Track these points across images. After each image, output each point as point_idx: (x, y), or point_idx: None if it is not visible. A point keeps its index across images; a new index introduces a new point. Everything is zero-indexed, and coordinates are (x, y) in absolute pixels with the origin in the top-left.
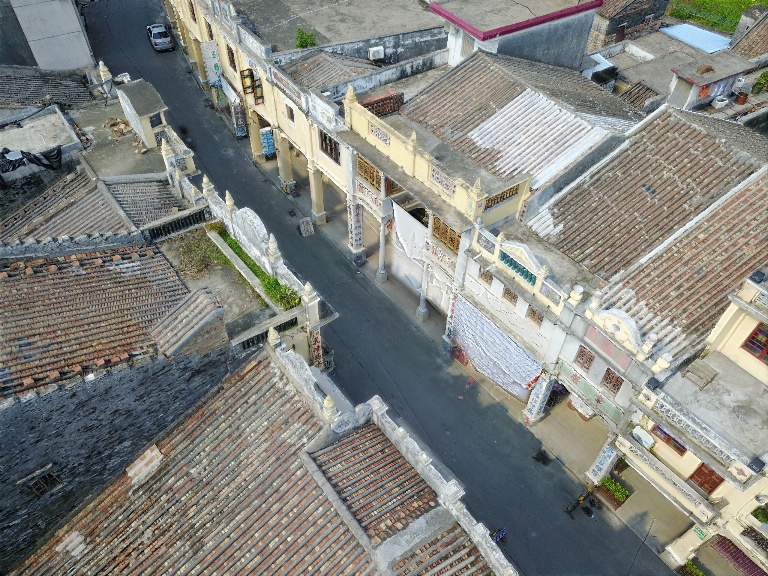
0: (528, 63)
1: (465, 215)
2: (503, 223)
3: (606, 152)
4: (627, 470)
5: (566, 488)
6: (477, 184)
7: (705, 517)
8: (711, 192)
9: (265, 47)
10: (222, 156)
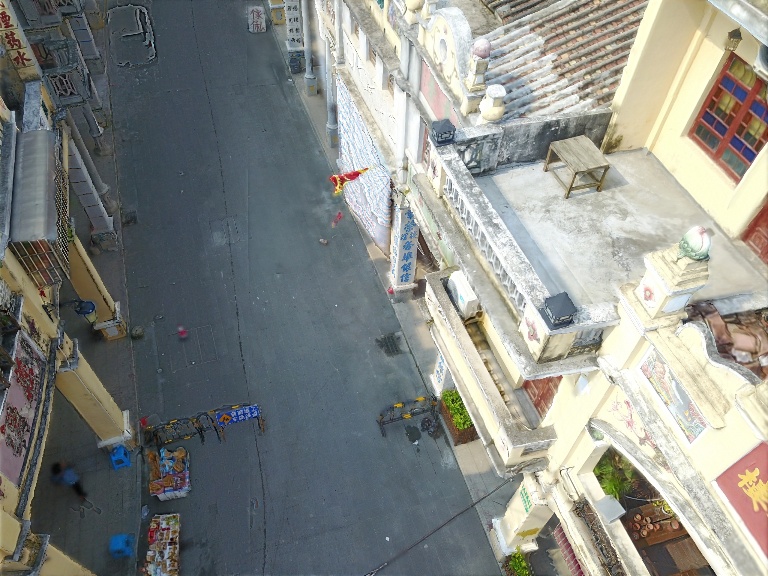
0: None
1: None
2: None
3: None
4: None
5: (400, 393)
6: None
7: (506, 452)
8: None
9: None
10: None
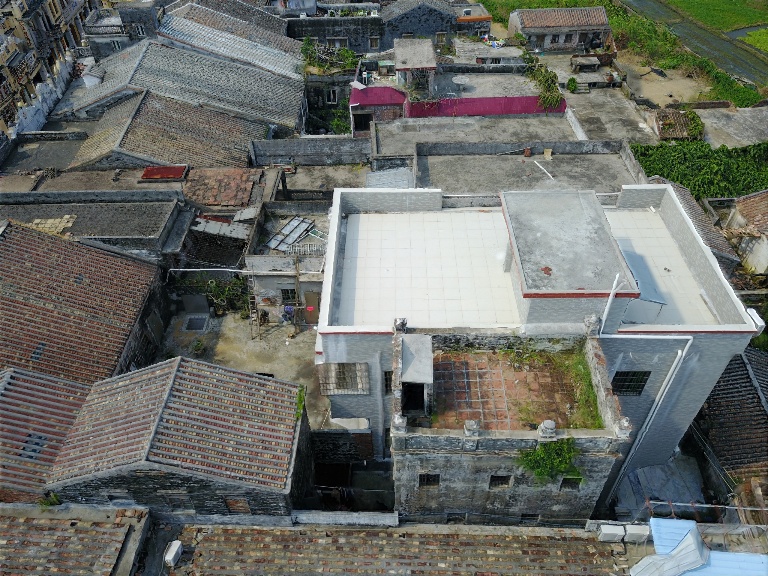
0: None
1: None
2: None
3: (172, 0)
4: None
5: None
6: None
7: None
8: None
9: None
10: None
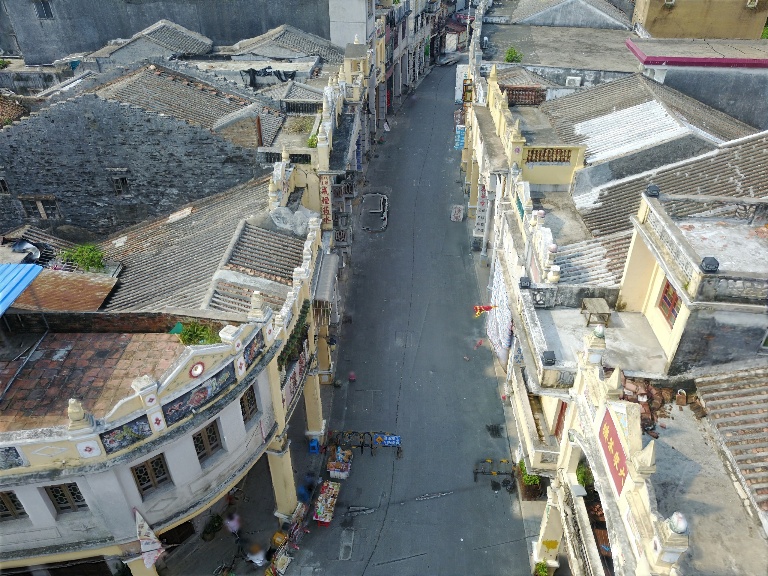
0: (702, 105)
1: None
2: (552, 191)
3: (686, 154)
4: None
5: (494, 460)
6: (516, 125)
7: (532, 458)
8: None
9: (477, 53)
10: (443, 161)
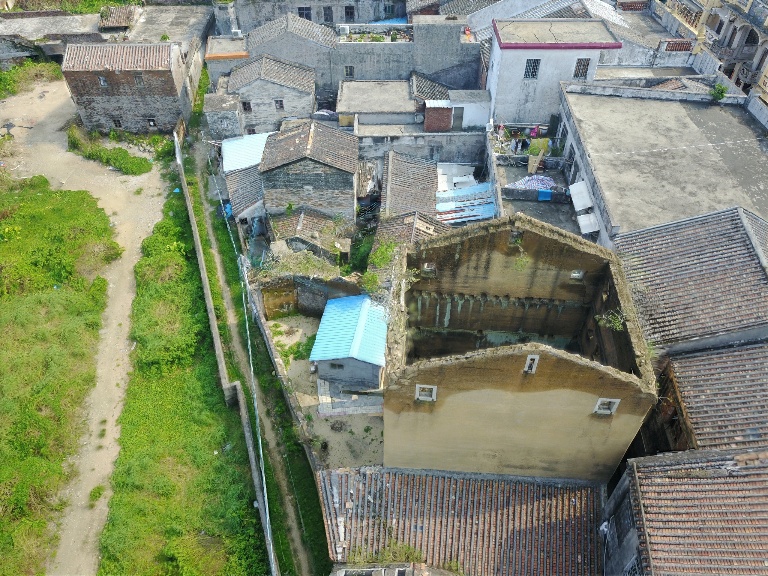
0: None
1: None
2: None
3: None
4: None
5: None
6: None
7: None
8: None
9: None
10: None
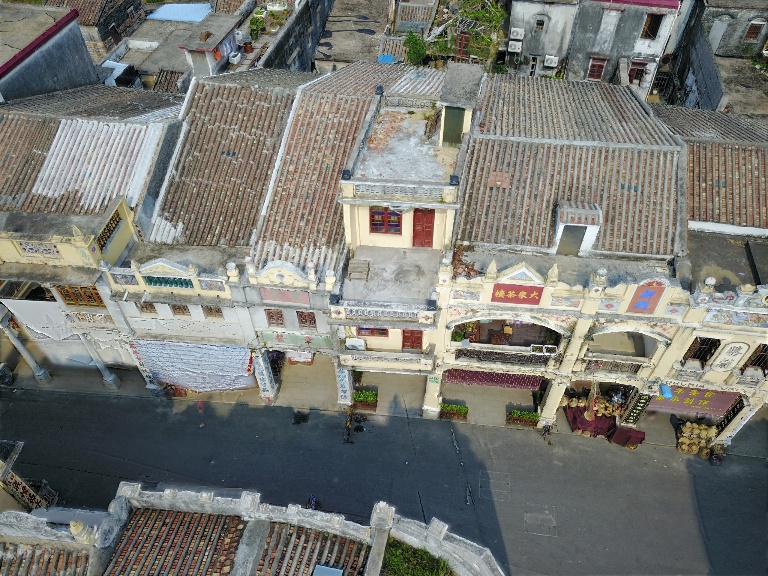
0: (45, 97)
1: (85, 267)
2: (127, 252)
3: (174, 141)
4: (363, 377)
5: (333, 426)
6: (76, 232)
7: (429, 366)
8: (275, 131)
9: None
10: None
